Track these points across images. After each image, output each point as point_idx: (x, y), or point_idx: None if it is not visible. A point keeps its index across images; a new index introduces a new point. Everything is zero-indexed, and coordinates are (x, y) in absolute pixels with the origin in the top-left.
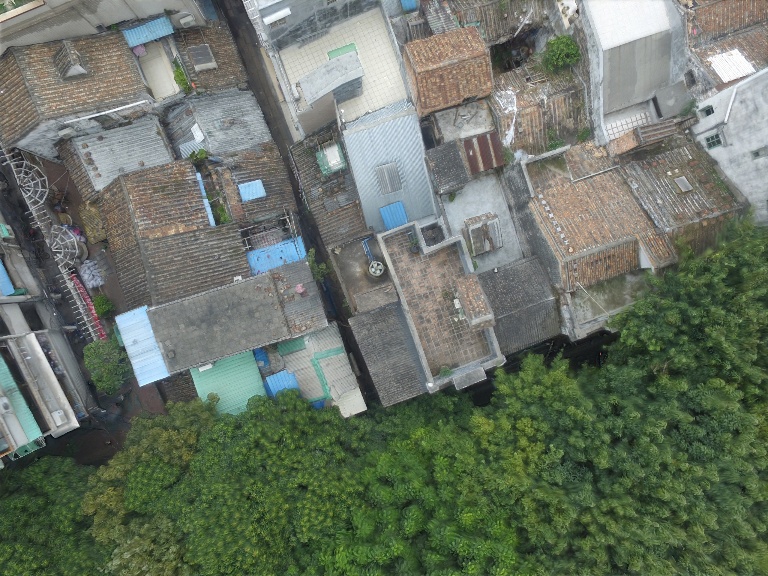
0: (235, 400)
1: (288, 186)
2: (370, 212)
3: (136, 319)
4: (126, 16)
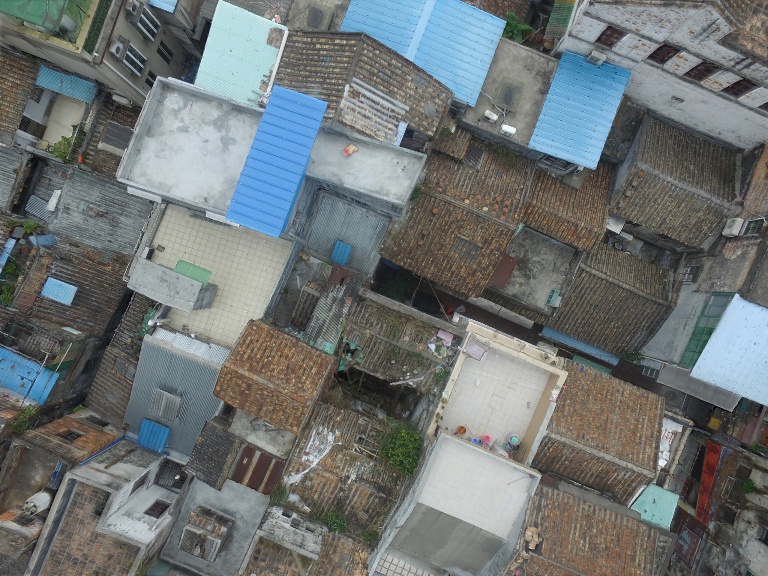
0: None
1: (111, 308)
2: (134, 413)
3: None
4: (47, 58)
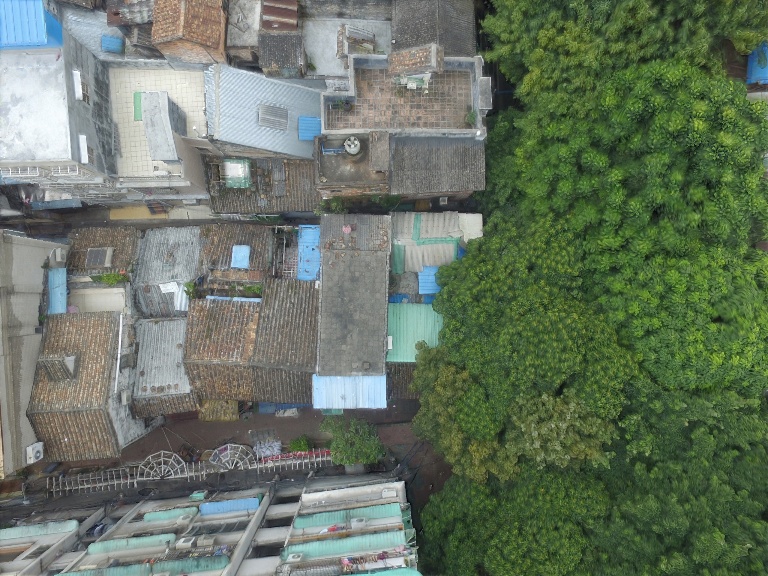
0: (430, 333)
1: (249, 227)
2: (299, 150)
3: (322, 389)
4: (35, 302)
